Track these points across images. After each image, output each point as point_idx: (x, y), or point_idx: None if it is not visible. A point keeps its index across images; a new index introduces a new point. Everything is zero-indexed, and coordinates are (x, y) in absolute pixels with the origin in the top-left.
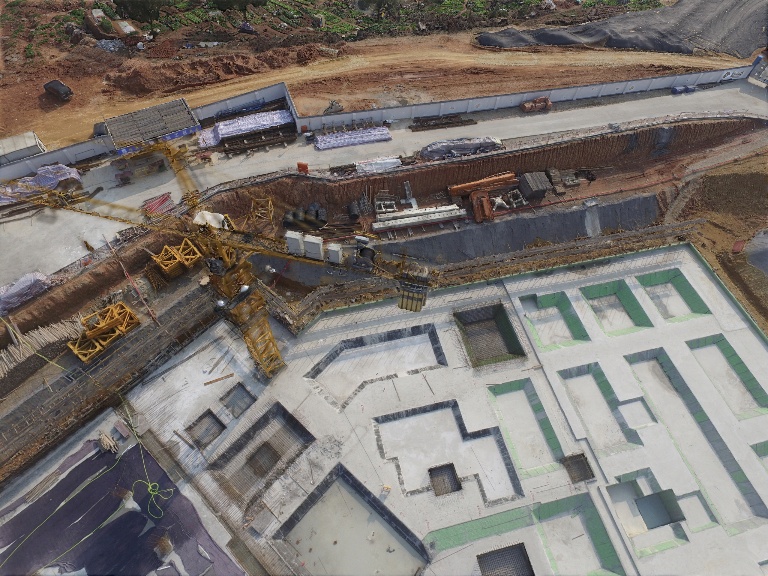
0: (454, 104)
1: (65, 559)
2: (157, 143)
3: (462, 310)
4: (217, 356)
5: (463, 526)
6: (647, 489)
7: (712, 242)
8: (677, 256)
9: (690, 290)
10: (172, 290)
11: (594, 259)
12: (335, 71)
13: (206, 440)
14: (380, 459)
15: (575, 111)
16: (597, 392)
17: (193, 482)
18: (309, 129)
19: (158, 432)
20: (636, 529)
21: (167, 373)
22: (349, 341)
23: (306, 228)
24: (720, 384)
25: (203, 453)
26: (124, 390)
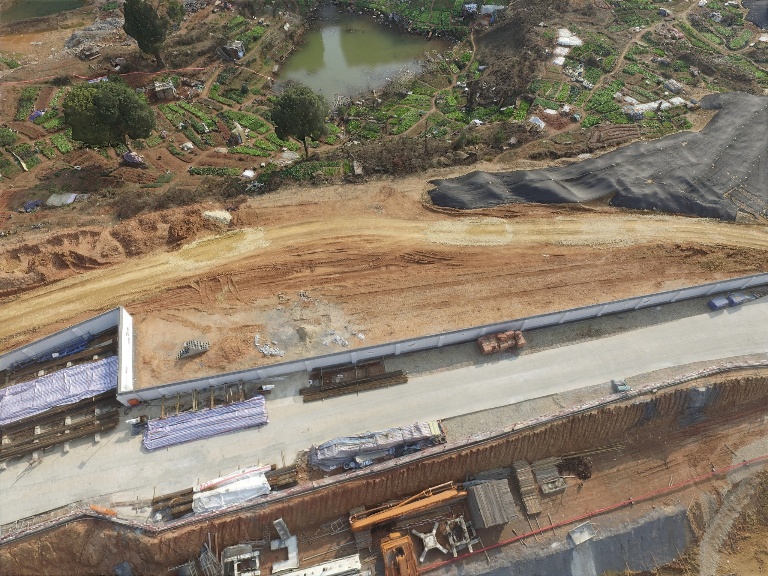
0: (373, 350)
1: None
2: None
3: None
4: None
5: None
6: None
7: None
8: None
9: None
10: None
11: None
12: (217, 261)
13: None
14: None
15: (561, 350)
16: None
17: None
18: (143, 400)
19: None
20: None
21: None
22: None
23: None
24: None
25: None
26: None
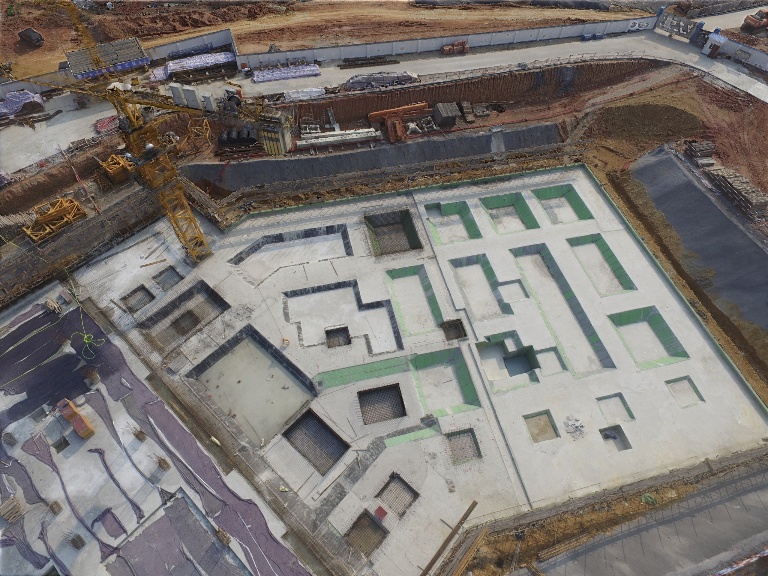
0: (379, 46)
1: (10, 386)
2: (109, 72)
3: (372, 214)
4: (154, 246)
5: (348, 370)
6: (512, 347)
7: (604, 163)
8: (572, 175)
9: (579, 201)
10: (117, 191)
11: (495, 176)
12: (281, 24)
13: (138, 307)
14: (284, 322)
15: (490, 54)
16: (482, 277)
17: (122, 335)
18: (248, 67)
19: (97, 300)
20: (500, 378)
21: (109, 258)
22: (270, 237)
23: (238, 145)
24: (592, 272)
25: (134, 315)
26: (71, 269)
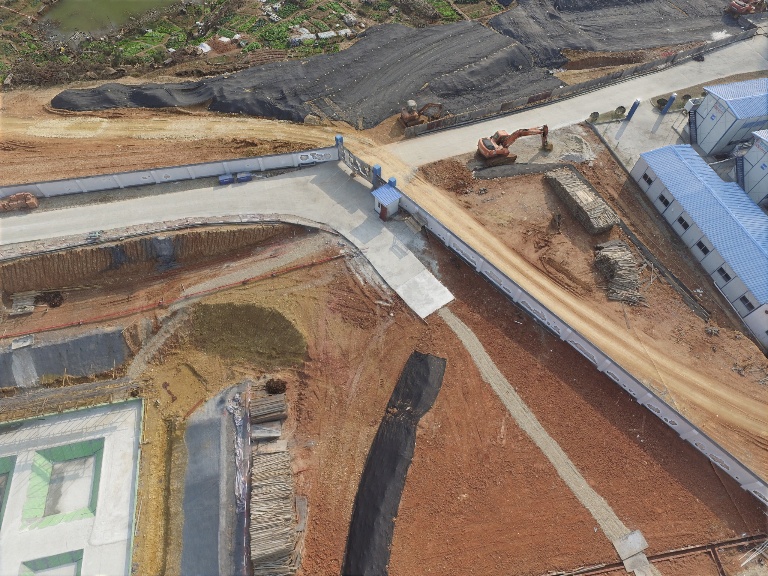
0: None
1: None
2: None
3: None
4: None
5: None
6: None
7: (171, 399)
8: (117, 418)
9: (98, 473)
10: None
11: None
12: None
13: None
14: None
15: (67, 210)
16: None
17: None
18: None
19: None
20: None
21: None
22: None
23: None
24: None
25: None
26: None
